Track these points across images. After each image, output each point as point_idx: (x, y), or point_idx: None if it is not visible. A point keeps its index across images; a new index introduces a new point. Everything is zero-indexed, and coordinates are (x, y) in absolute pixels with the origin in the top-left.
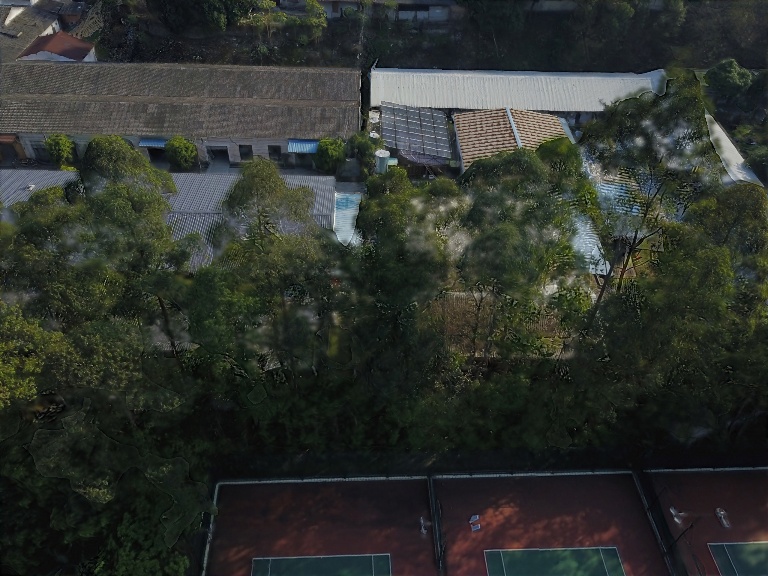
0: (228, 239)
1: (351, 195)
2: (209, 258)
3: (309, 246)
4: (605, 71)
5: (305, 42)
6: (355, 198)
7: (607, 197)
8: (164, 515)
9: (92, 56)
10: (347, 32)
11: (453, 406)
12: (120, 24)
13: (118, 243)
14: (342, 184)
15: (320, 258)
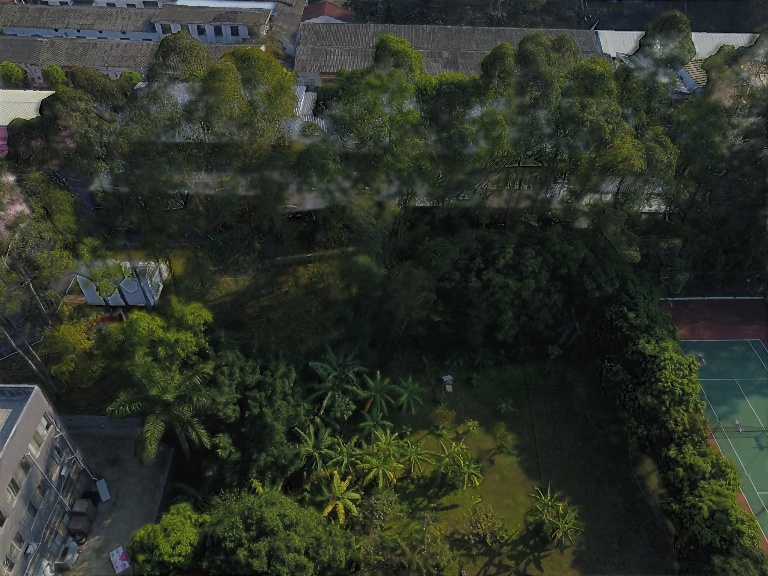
0: (726, 86)
1: None
2: None
3: None
4: None
5: (532, 9)
6: None
7: None
8: (665, 276)
9: None
10: (561, 1)
11: None
12: None
13: (661, 87)
14: None
15: None
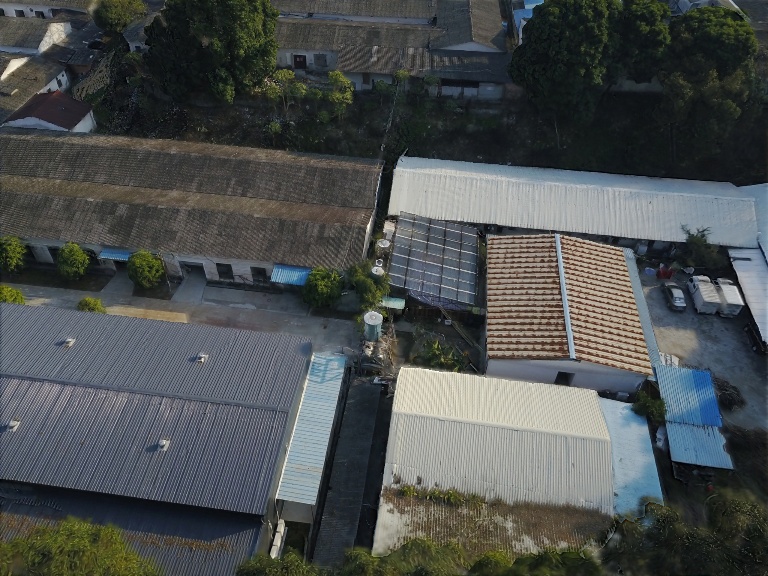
0: None
1: (333, 359)
2: None
3: None
4: (695, 176)
5: (325, 120)
6: (337, 364)
7: None
8: None
9: (89, 120)
10: (378, 108)
11: None
12: (125, 83)
13: None
14: (335, 322)
15: None
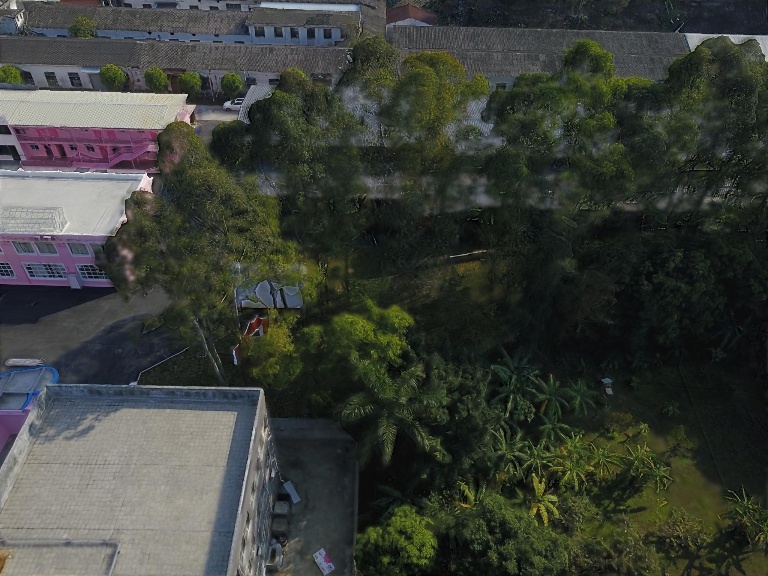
0: None
1: None
2: None
3: None
4: None
5: (614, 12)
6: None
7: None
8: None
9: None
10: (642, 4)
11: None
12: None
13: None
14: None
15: None
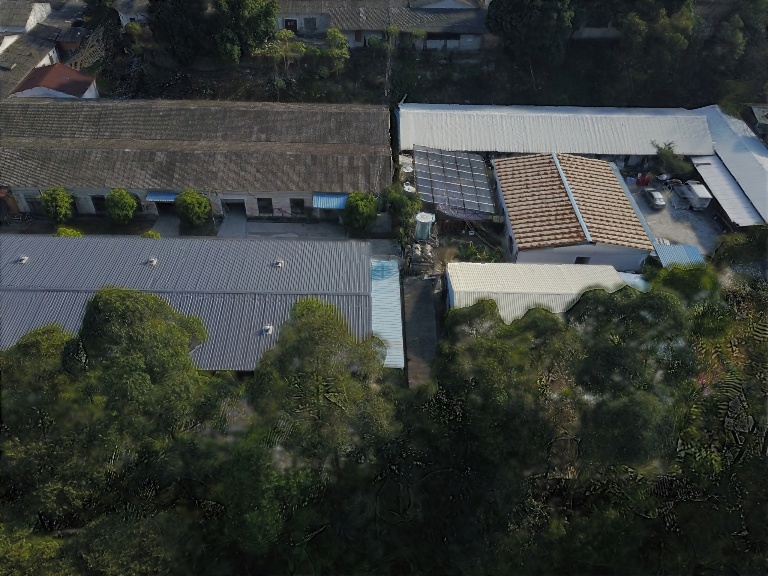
0: (274, 406)
1: (387, 262)
2: (241, 395)
3: (381, 419)
4: (652, 105)
5: (326, 75)
6: (391, 265)
7: (762, 346)
8: None
9: (93, 90)
10: (371, 63)
11: (531, 555)
12: (123, 54)
13: (131, 416)
14: (372, 241)
15: (393, 430)
